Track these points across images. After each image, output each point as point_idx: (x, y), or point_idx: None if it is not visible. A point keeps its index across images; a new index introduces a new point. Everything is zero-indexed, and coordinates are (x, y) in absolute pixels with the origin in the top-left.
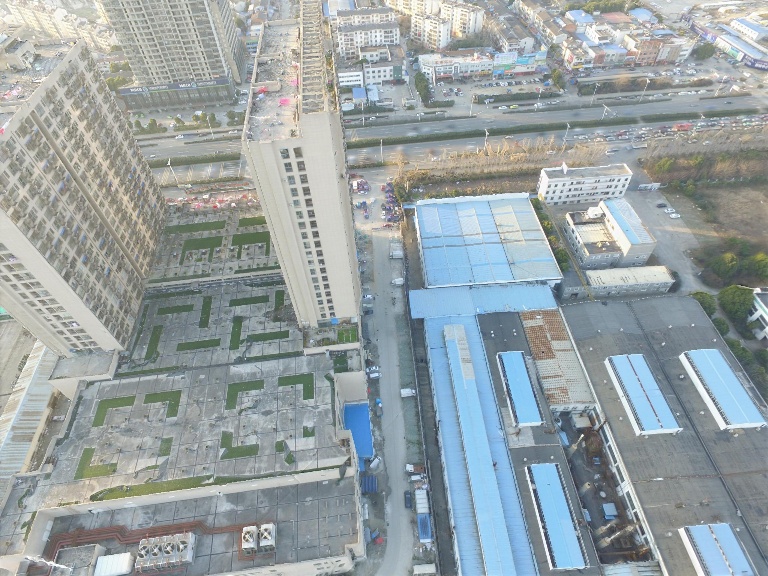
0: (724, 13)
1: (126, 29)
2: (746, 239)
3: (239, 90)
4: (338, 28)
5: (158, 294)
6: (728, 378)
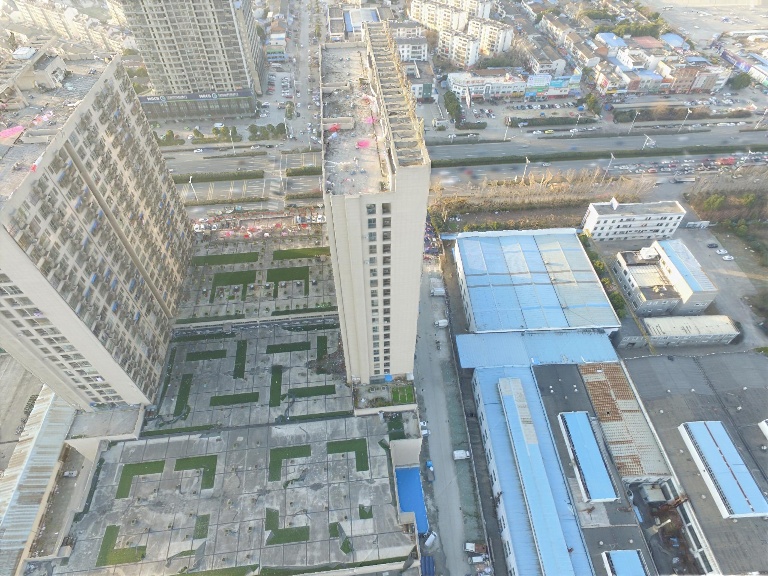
0: (754, 42)
1: (147, 35)
2: None
3: (260, 102)
4: None
5: (186, 336)
6: None
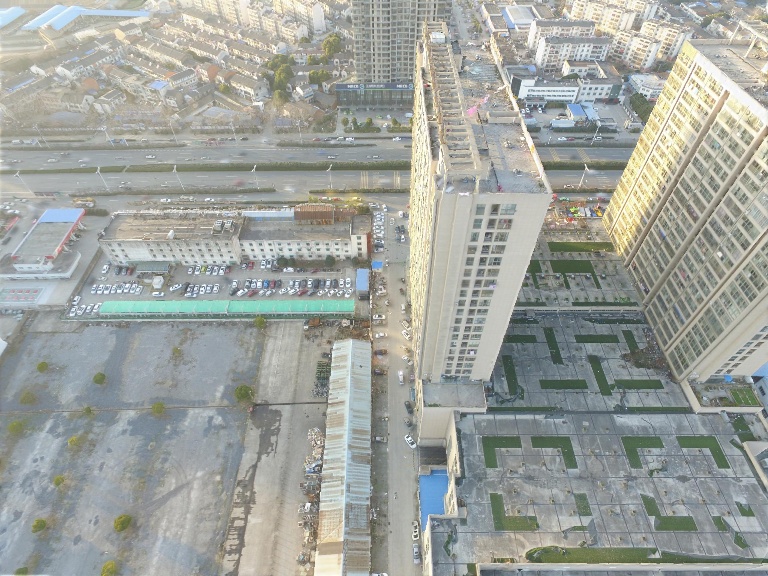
0: None
1: (366, 25)
2: None
3: None
4: (545, 39)
5: None
6: None
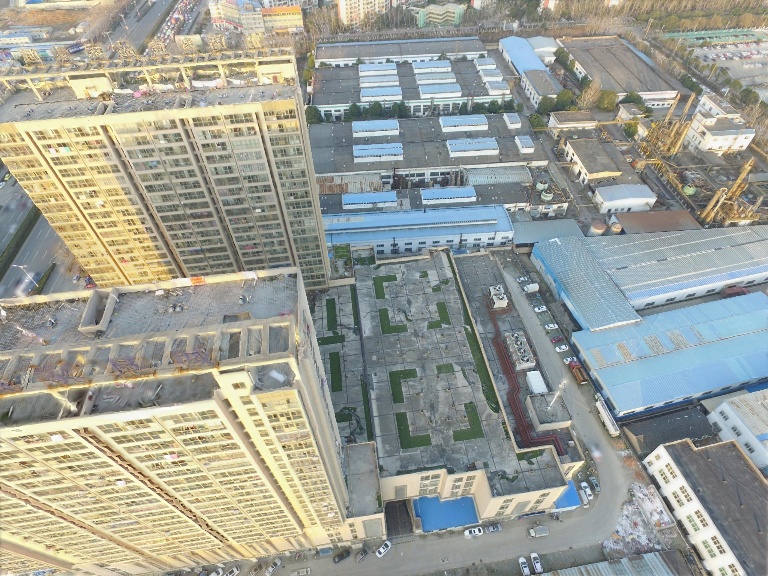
0: None
1: None
2: None
3: None
4: None
5: None
6: (372, 122)
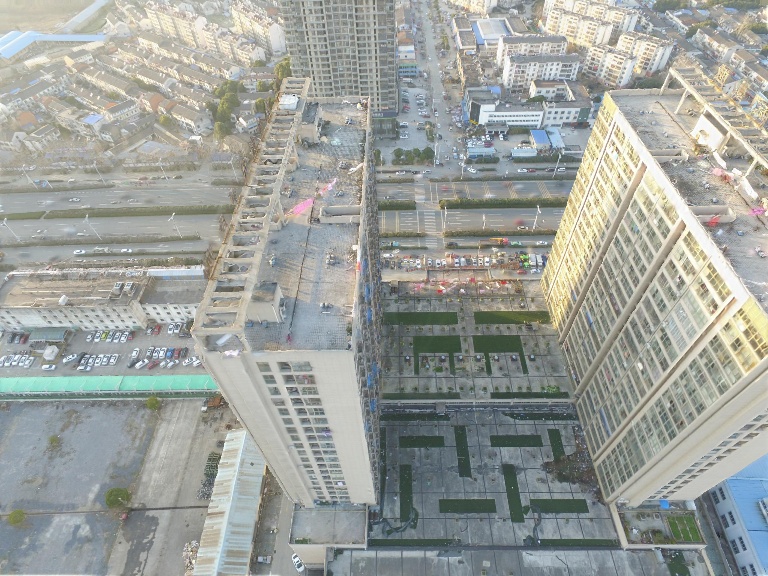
0: None
1: (302, 53)
2: None
3: (397, 121)
4: (510, 58)
5: (394, 413)
6: None
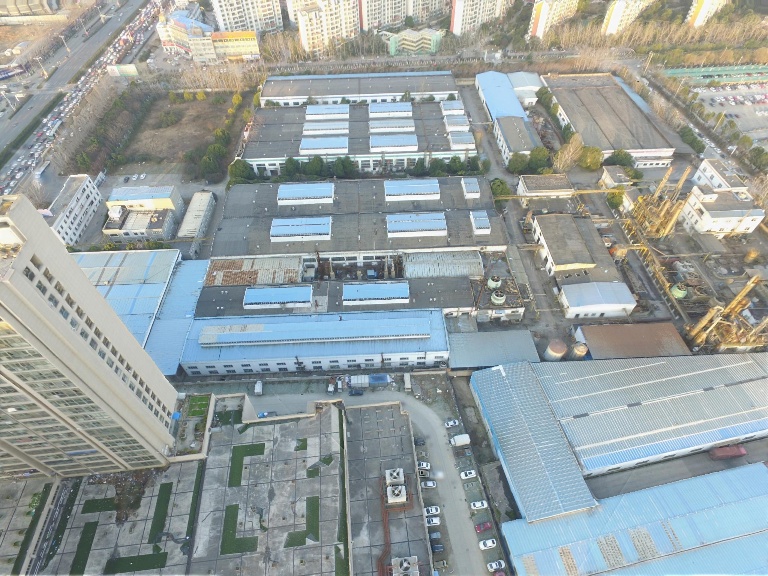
0: None
1: None
2: (188, 151)
3: None
4: None
5: None
6: (302, 187)
